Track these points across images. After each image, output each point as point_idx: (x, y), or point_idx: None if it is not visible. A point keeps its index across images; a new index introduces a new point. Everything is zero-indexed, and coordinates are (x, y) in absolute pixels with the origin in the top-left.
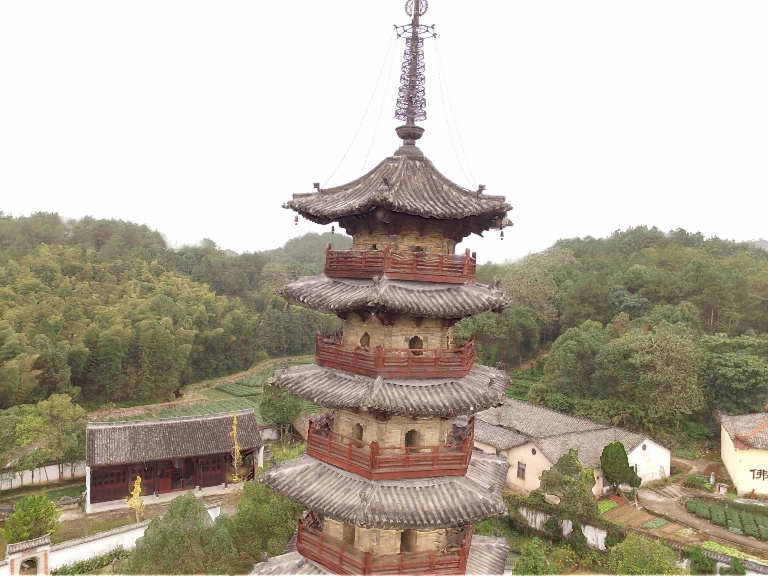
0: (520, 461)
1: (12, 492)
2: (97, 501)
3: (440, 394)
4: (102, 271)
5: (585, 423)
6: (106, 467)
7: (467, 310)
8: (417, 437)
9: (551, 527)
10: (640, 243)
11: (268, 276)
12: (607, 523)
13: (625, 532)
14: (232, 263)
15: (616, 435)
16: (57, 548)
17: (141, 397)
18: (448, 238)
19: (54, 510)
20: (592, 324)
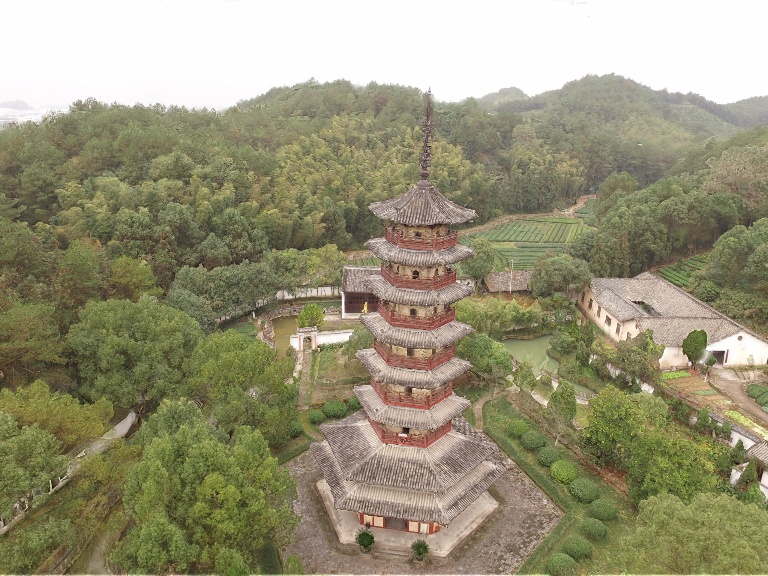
0: (629, 332)
1: (307, 299)
2: (349, 312)
3: (420, 296)
4: (375, 140)
5: (705, 311)
6: (352, 293)
7: (426, 265)
8: (416, 312)
9: (619, 379)
10: None
11: (518, 136)
12: (657, 384)
13: (666, 392)
14: (489, 122)
15: (721, 325)
16: (321, 334)
17: None
18: (431, 229)
19: (321, 314)
20: (765, 222)
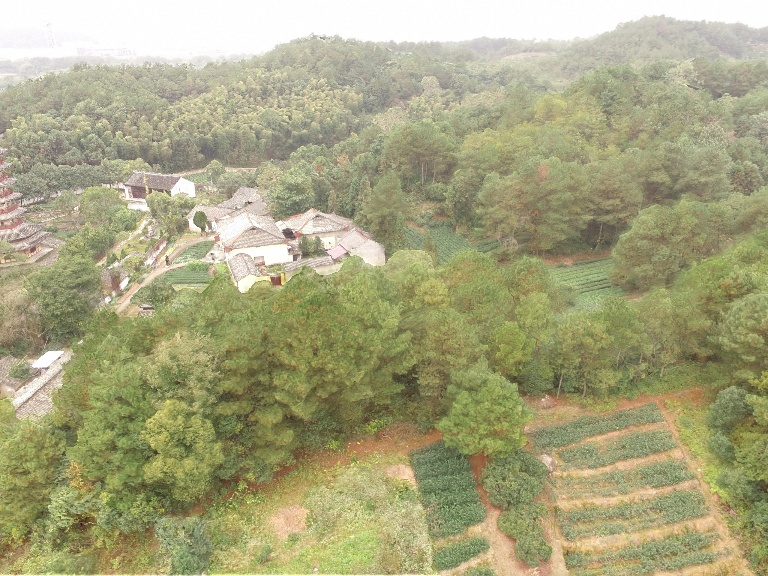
0: None
1: None
2: (135, 197)
3: None
4: (272, 90)
5: None
6: None
7: None
8: None
9: None
10: (574, 87)
11: (425, 86)
12: None
13: None
14: None
15: None
16: None
17: (241, 163)
18: None
19: None
20: None
